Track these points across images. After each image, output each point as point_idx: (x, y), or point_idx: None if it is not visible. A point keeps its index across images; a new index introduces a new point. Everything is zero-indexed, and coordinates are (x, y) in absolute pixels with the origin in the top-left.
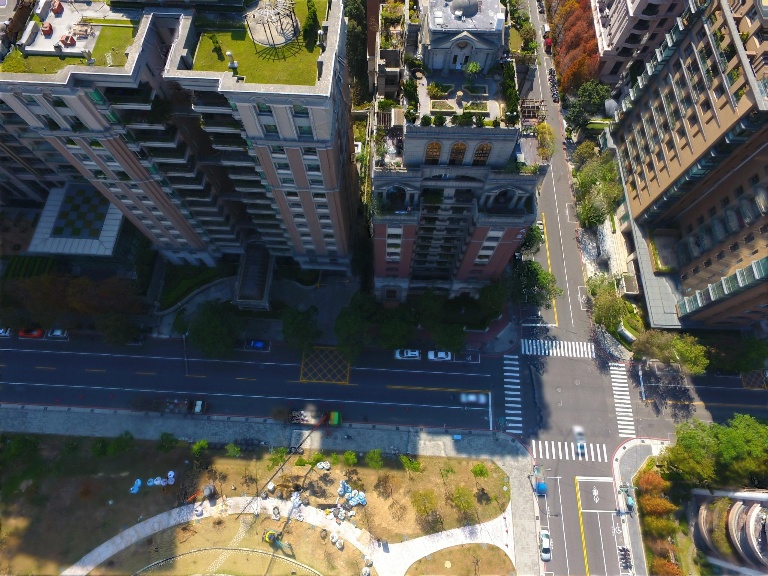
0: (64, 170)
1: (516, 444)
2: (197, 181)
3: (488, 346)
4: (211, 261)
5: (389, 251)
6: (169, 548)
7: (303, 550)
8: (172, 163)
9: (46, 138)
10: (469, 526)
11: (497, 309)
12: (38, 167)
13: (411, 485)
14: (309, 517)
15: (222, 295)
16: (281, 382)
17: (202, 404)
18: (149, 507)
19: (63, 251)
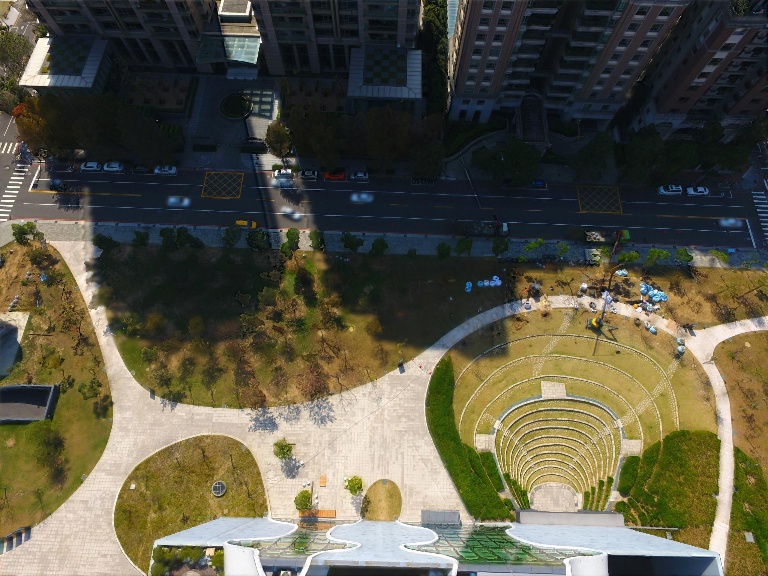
0: (373, 27)
1: None
2: (556, 3)
3: (736, 184)
4: (488, 114)
5: (704, 70)
6: (508, 334)
7: (622, 335)
8: None
9: None
10: (756, 318)
11: None
12: (343, 27)
13: (700, 287)
14: (621, 310)
15: None
16: (564, 213)
17: (507, 225)
18: (484, 302)
19: (379, 95)
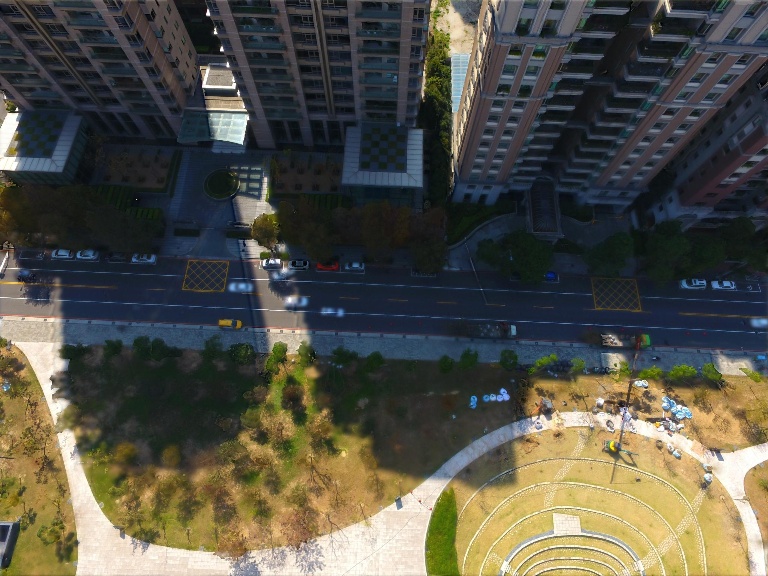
0: (370, 107)
1: None
2: None
3: (765, 277)
4: (495, 198)
5: (736, 171)
6: (517, 458)
7: (643, 459)
8: (570, 80)
9: (497, 47)
10: None
11: None
12: (338, 105)
13: (727, 401)
14: (641, 430)
15: (501, 231)
16: (578, 310)
17: None
18: (491, 421)
19: (376, 183)
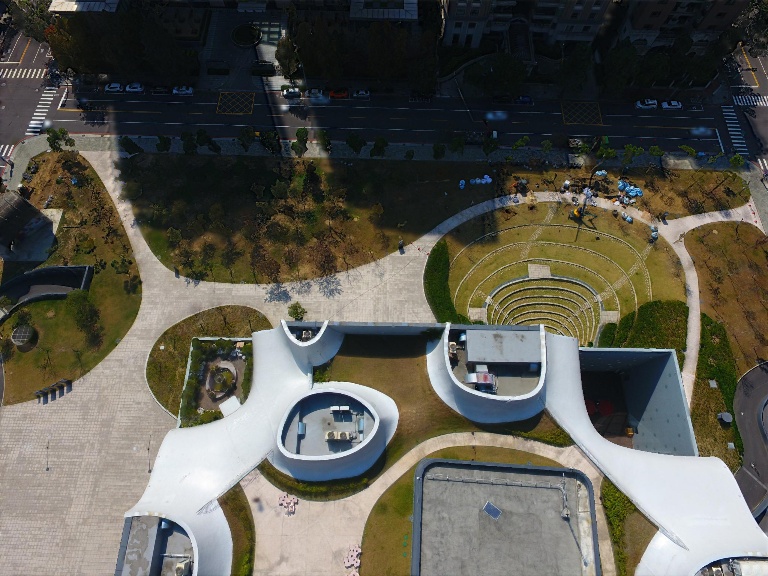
0: None
1: (746, 161)
2: None
3: (707, 100)
4: (479, 38)
5: None
6: (498, 223)
7: (602, 224)
8: None
9: None
10: (724, 210)
11: (735, 47)
12: None
13: (673, 185)
14: (600, 204)
15: None
16: (549, 124)
17: None
18: (476, 197)
19: (378, 17)
